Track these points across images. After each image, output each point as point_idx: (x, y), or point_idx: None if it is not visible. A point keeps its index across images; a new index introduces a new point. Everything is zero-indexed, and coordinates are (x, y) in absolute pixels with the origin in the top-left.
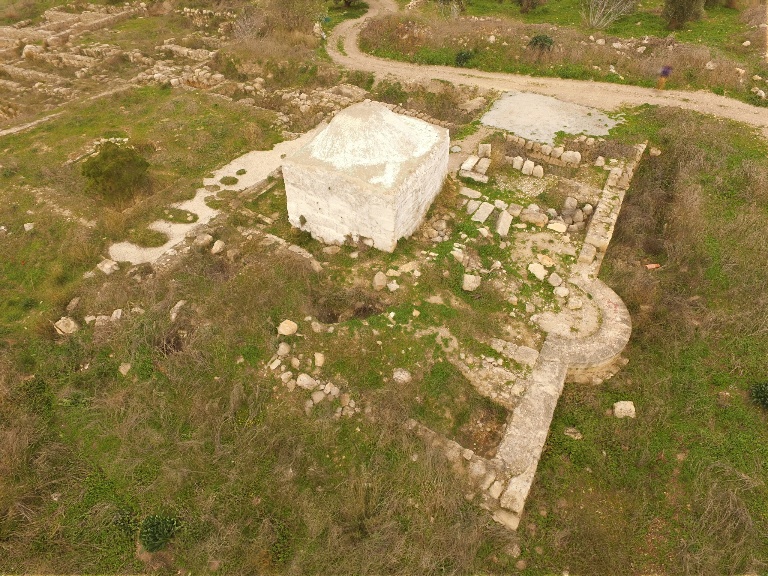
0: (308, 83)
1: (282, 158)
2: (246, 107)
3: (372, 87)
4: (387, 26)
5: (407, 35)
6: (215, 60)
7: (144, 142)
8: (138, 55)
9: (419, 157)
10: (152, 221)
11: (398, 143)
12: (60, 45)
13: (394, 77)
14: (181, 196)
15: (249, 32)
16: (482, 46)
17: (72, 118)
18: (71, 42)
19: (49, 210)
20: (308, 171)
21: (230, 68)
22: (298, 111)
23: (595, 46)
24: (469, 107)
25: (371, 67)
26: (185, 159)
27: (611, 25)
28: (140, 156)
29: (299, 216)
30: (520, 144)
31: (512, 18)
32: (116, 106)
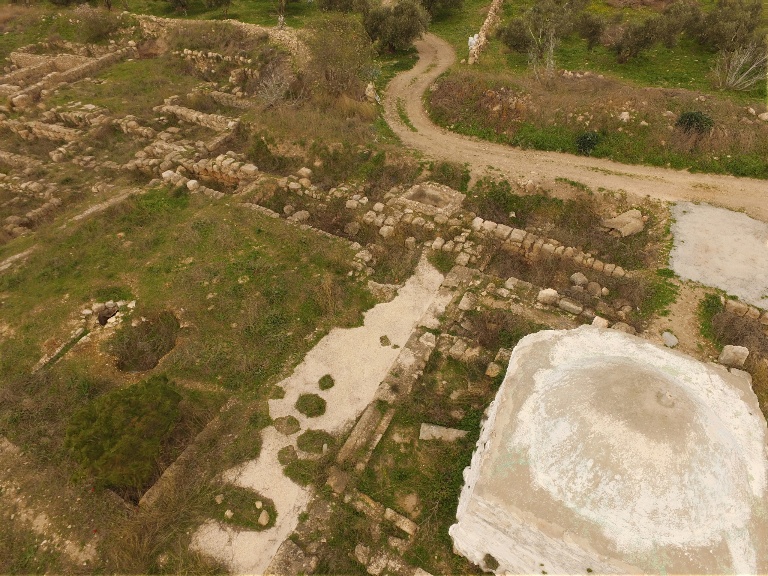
0: (373, 176)
1: (384, 346)
2: (303, 232)
3: (468, 187)
4: (469, 92)
5: (499, 106)
6: (236, 132)
7: (160, 309)
8: (133, 125)
9: (764, 496)
10: (196, 526)
11: (732, 479)
12: (29, 105)
13: (499, 173)
14: (239, 456)
15: (277, 92)
16: (613, 126)
17: (47, 263)
18: (43, 102)
19: (8, 516)
20: (541, 531)
21: (261, 150)
22: (376, 233)
23: (767, 126)
24: (624, 228)
25: (458, 153)
26: (231, 354)
27: (756, 86)
28: (164, 375)
29: (483, 553)
30: (758, 321)
31: (609, 69)
32: (112, 232)
